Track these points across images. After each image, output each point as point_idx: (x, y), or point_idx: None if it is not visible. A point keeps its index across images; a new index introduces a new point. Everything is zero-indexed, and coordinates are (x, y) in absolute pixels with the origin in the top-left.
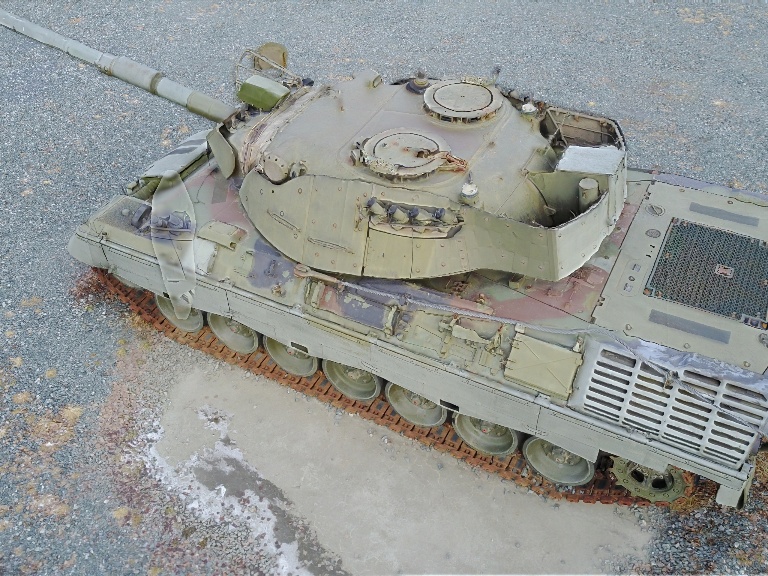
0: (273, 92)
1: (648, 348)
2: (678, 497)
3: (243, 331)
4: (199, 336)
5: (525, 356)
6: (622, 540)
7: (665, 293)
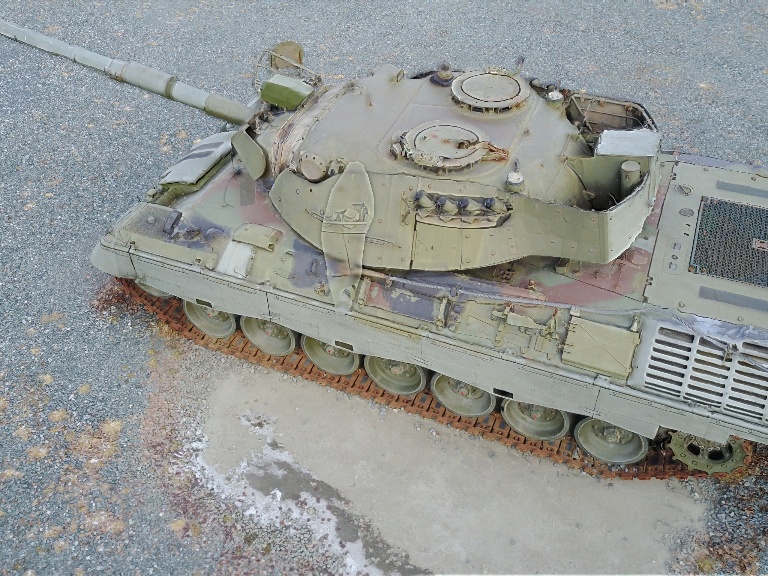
0: (298, 91)
1: (704, 323)
2: (737, 467)
3: (277, 333)
4: (230, 341)
5: (582, 339)
6: (678, 513)
7: (709, 269)
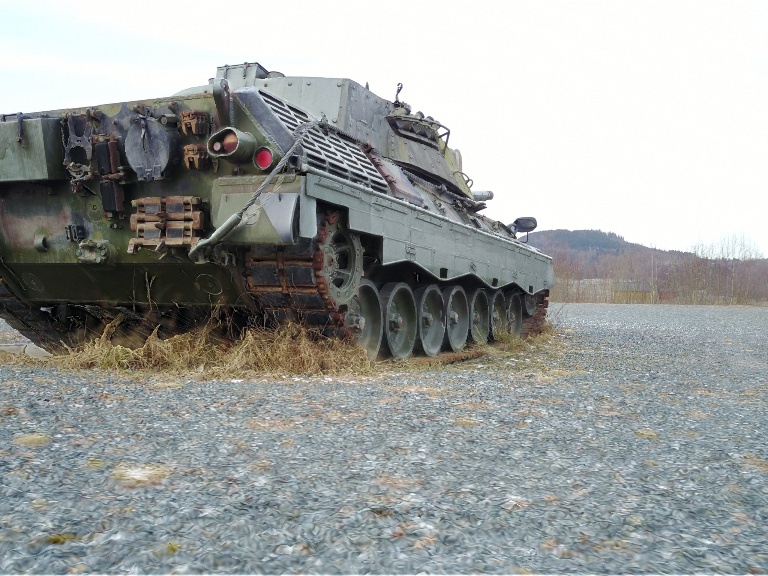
0: None
1: None
2: None
3: None
4: None
5: None
6: None
7: None
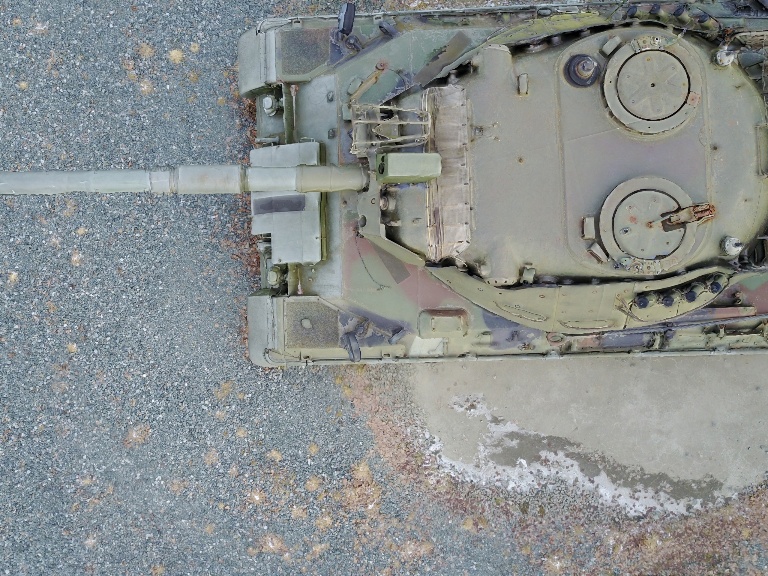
0: (430, 175)
1: None
2: None
3: None
4: None
5: None
6: None
7: None
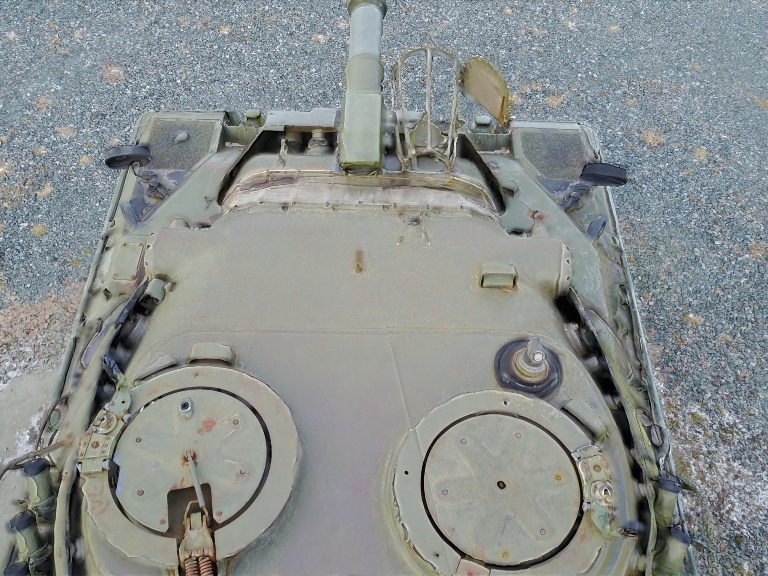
0: (344, 143)
1: None
2: None
3: None
4: None
5: None
6: None
7: None
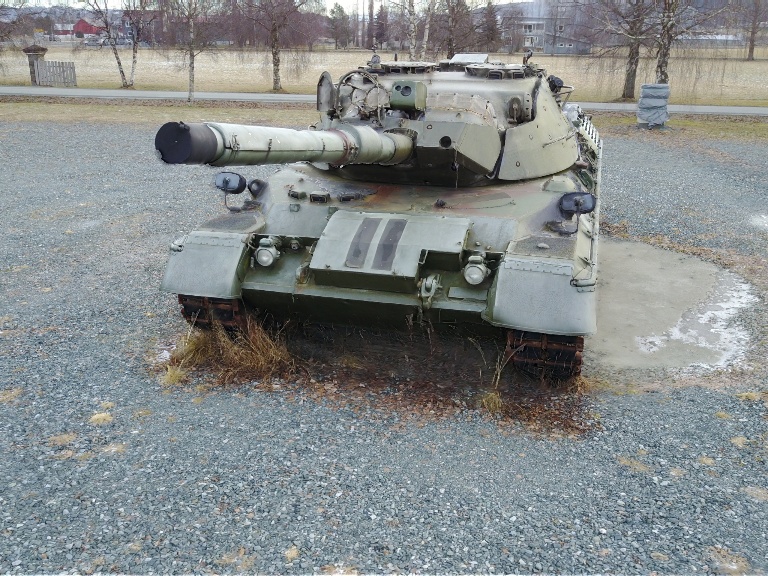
0: None
1: None
2: None
3: None
4: None
5: None
6: None
7: None
